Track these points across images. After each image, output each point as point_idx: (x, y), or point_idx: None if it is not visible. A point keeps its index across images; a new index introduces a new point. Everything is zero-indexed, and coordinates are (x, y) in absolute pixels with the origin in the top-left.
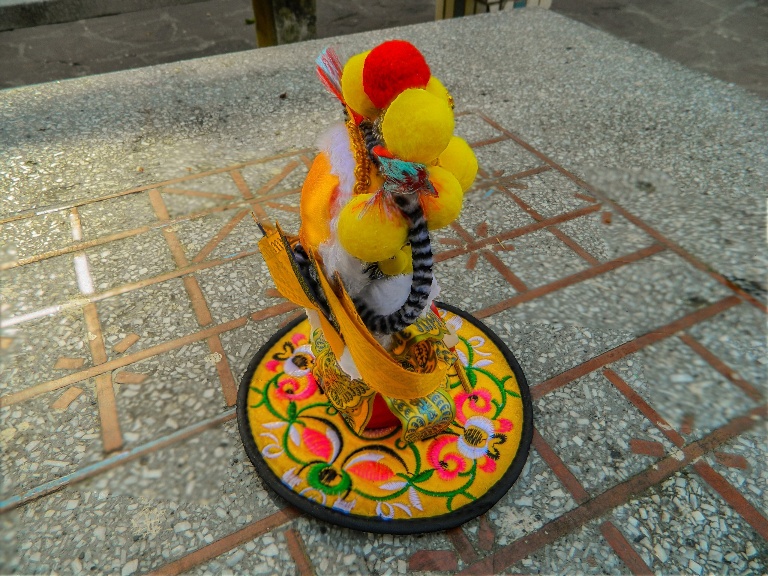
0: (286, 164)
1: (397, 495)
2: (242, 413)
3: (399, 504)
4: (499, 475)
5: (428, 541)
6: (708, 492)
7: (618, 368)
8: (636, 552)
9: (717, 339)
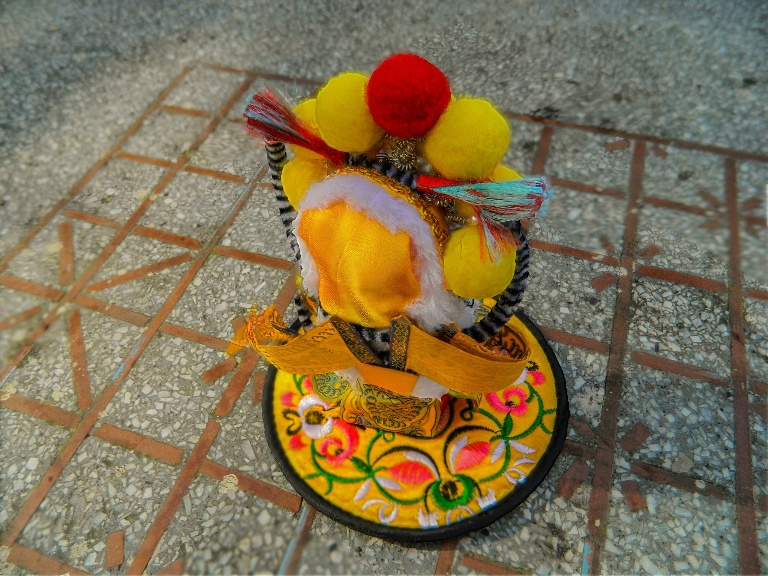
0: (57, 232)
1: (509, 456)
2: (327, 507)
3: (518, 462)
4: (552, 379)
5: (556, 468)
6: (658, 284)
7: (535, 235)
8: (664, 358)
9: (566, 168)
